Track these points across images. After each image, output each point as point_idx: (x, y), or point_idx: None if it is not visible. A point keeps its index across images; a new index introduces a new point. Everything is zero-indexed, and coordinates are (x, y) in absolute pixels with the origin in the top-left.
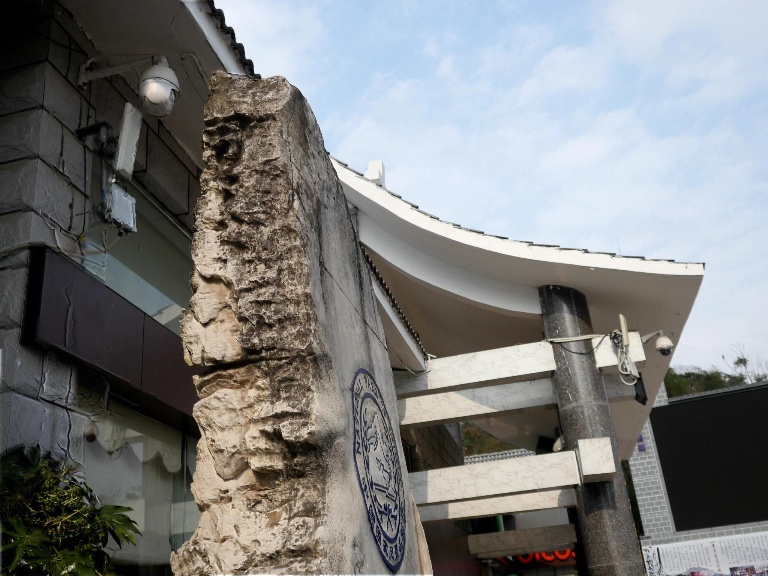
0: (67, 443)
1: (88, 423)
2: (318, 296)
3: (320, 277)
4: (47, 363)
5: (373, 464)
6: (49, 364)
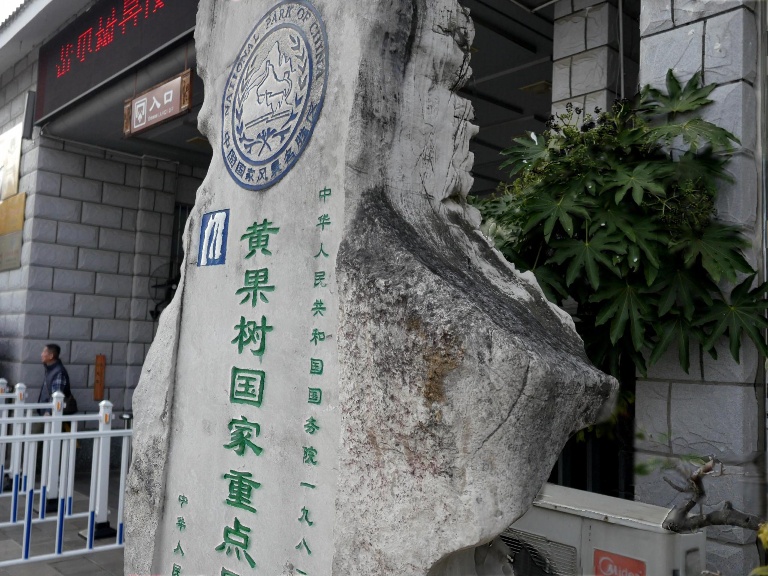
0: (702, 57)
1: (744, 14)
2: (205, 29)
3: (214, 6)
4: (641, 1)
5: (249, 107)
6: (643, 1)
